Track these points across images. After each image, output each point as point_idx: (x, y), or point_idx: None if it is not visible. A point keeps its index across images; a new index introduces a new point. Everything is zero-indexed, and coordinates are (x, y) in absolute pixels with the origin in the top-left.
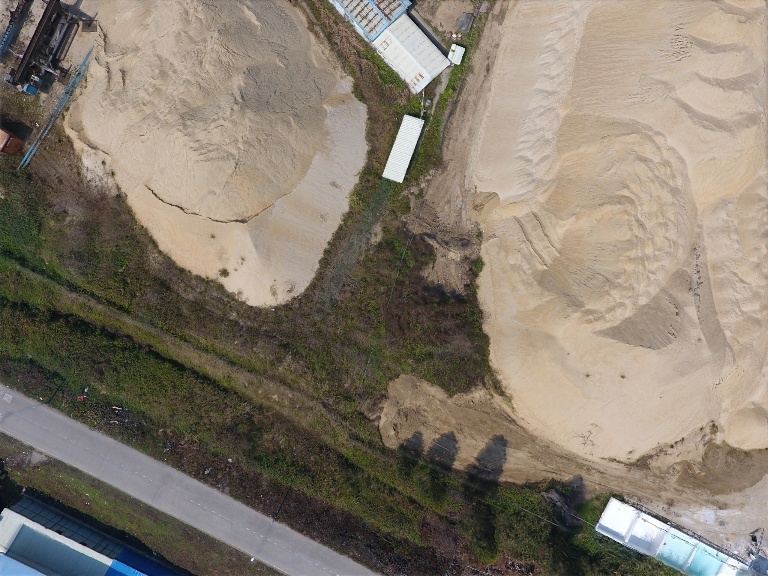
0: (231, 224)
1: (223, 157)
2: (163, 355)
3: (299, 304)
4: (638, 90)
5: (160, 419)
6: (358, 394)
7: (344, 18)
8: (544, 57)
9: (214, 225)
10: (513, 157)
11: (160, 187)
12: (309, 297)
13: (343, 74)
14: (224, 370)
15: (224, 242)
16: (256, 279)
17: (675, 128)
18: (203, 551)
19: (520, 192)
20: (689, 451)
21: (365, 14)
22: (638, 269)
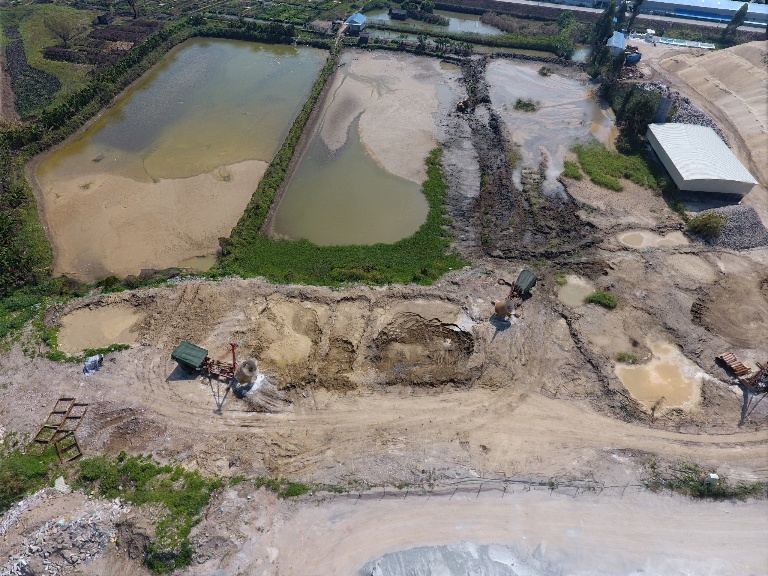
0: None
1: None
2: None
3: None
4: None
5: None
6: None
7: None
8: None
9: None
10: None
11: None
12: None
13: None
14: None
15: None
16: None
17: None
18: None
19: None
20: None
21: None
22: None
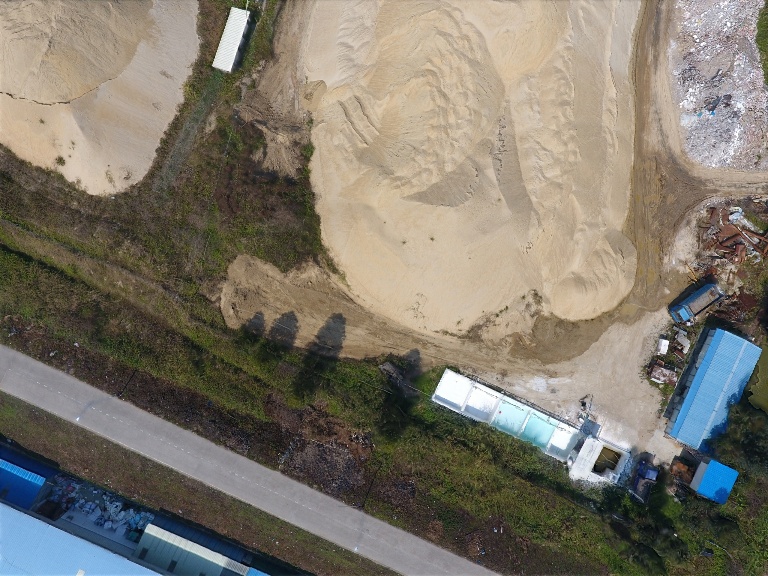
0: (55, 106)
1: (37, 36)
2: (11, 248)
3: (138, 192)
4: None
5: (5, 306)
6: (198, 276)
7: None
8: None
9: (40, 108)
10: (334, 44)
11: None
12: (148, 185)
13: None
14: (68, 258)
15: (54, 127)
16: (90, 164)
17: (469, 2)
18: (51, 431)
19: (342, 77)
20: (517, 321)
21: None
22: (441, 136)
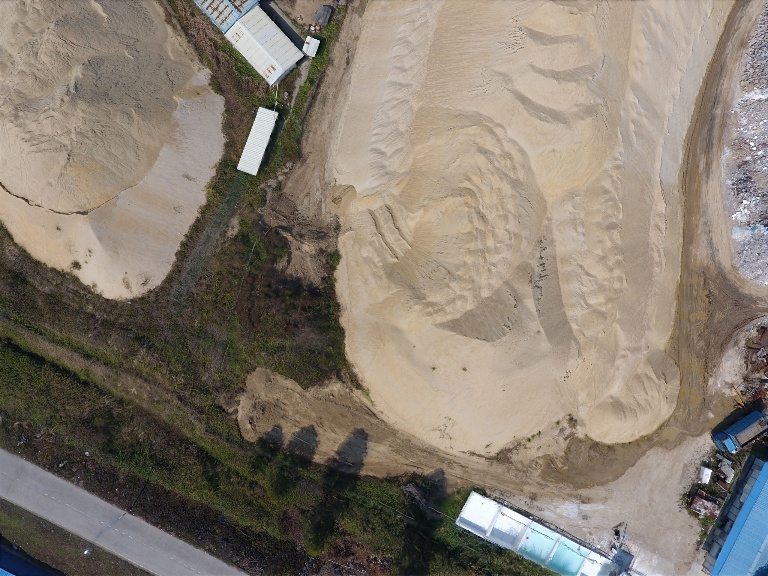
0: (73, 216)
1: (56, 148)
2: (23, 348)
3: (155, 297)
4: (480, 82)
5: (15, 412)
6: (215, 387)
7: (202, 10)
8: (397, 49)
9: (57, 217)
10: (366, 150)
11: (6, 179)
12: (166, 290)
13: (201, 66)
14: (81, 363)
15: (70, 234)
16: (106, 271)
17: (513, 120)
18: (58, 545)
19: (373, 185)
20: (549, 445)
21: (216, 6)
22: (478, 261)
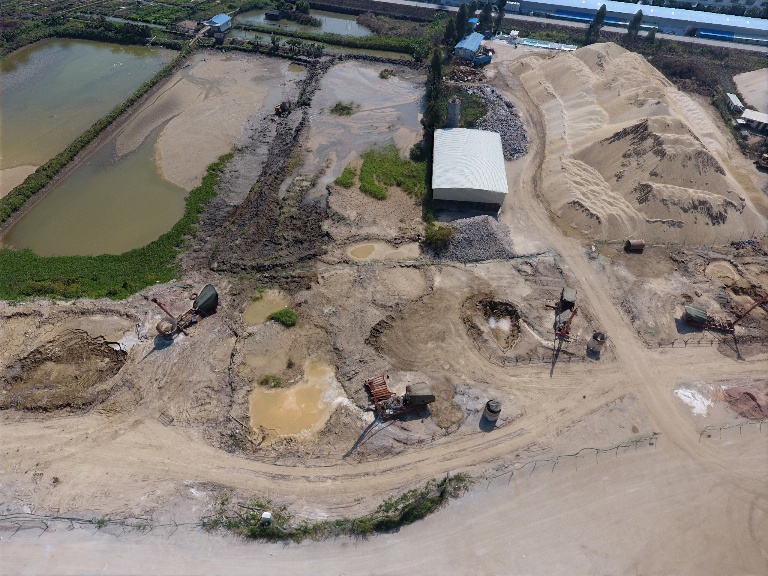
0: None
1: None
2: None
3: None
4: None
5: (752, 56)
6: None
7: None
8: None
9: None
10: None
11: None
12: None
13: None
14: None
15: None
16: None
17: None
18: None
19: None
20: None
21: None
22: None
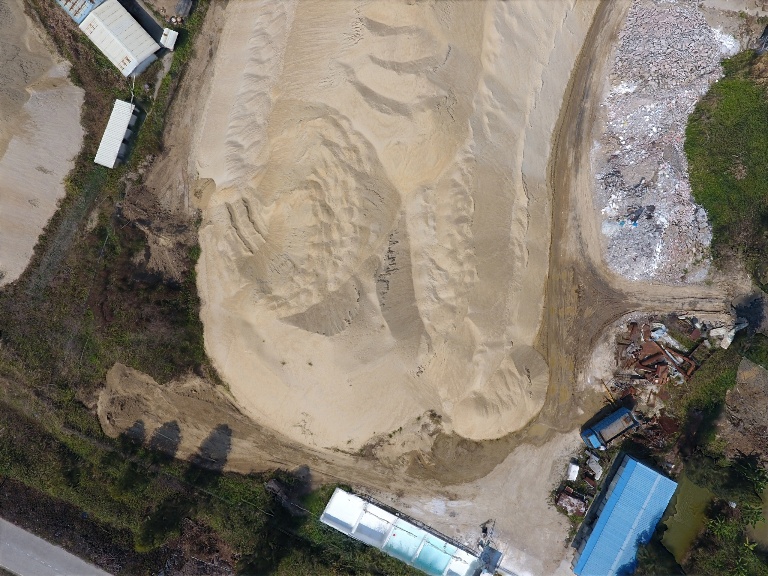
0: None
1: None
2: None
3: (14, 291)
4: (327, 74)
5: None
6: (74, 382)
7: None
8: (253, 41)
9: None
10: (223, 142)
11: None
12: (24, 284)
13: (60, 58)
14: None
15: None
16: None
17: (356, 112)
18: None
19: (230, 178)
20: (413, 441)
21: None
22: (322, 255)
